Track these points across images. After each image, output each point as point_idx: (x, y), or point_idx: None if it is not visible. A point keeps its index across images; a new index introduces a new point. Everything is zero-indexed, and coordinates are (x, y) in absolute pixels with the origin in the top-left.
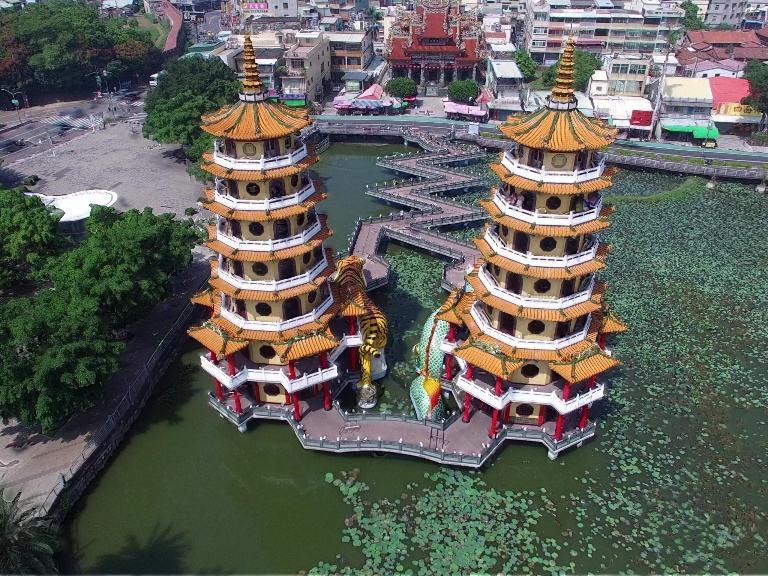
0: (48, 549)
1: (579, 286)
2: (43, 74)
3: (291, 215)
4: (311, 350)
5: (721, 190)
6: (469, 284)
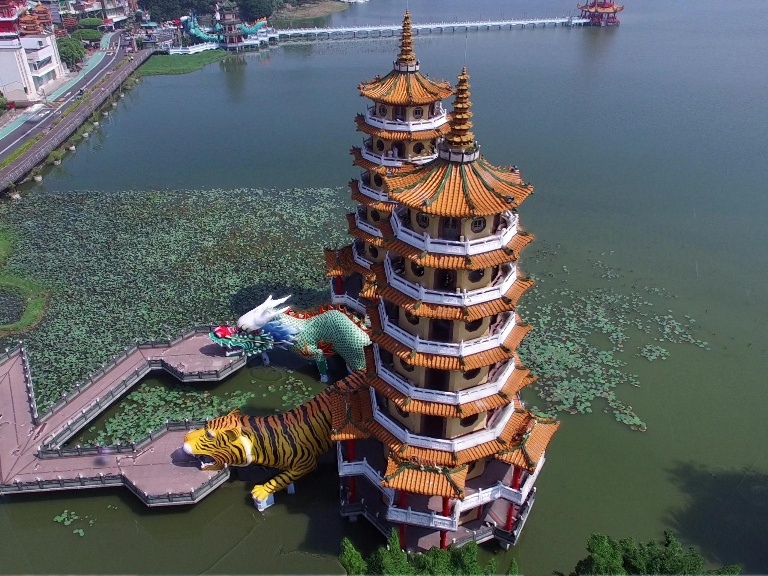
0: None
1: None
2: None
3: None
4: None
5: (4, 214)
6: (283, 322)
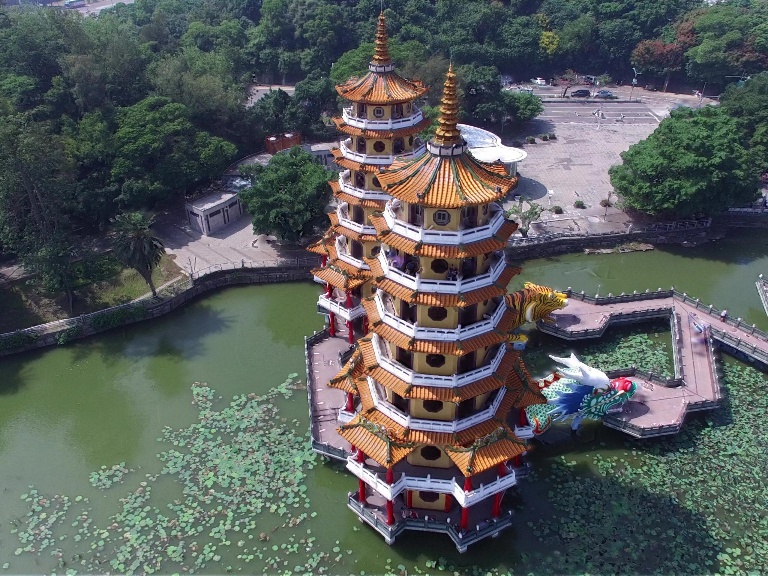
0: (132, 245)
1: (434, 374)
2: (692, 66)
3: (352, 168)
4: (330, 280)
5: None
6: None
